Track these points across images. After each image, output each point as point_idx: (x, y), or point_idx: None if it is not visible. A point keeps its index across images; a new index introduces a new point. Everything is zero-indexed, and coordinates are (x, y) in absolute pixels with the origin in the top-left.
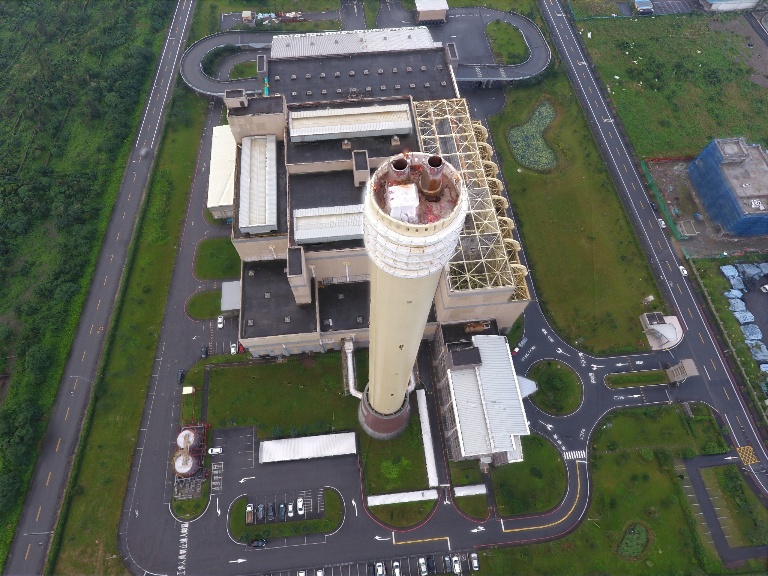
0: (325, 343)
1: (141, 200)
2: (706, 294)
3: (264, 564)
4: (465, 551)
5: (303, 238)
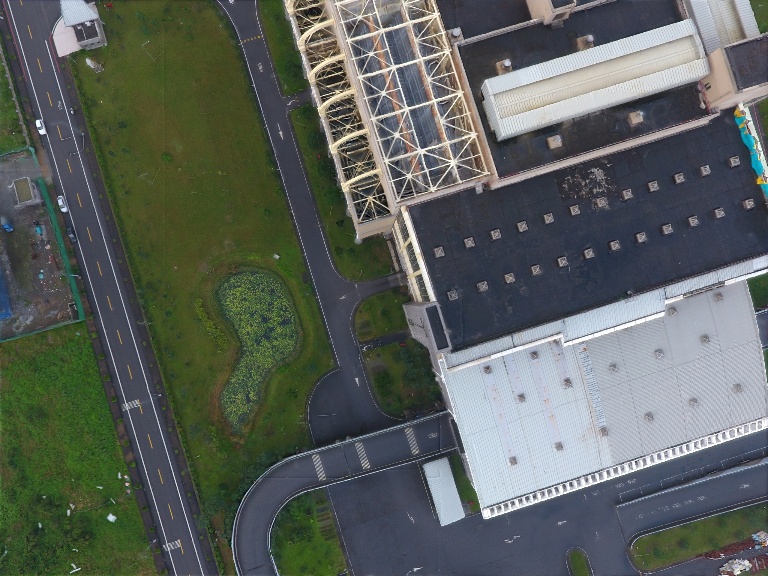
0: None
1: None
2: (14, 94)
3: None
4: None
5: None
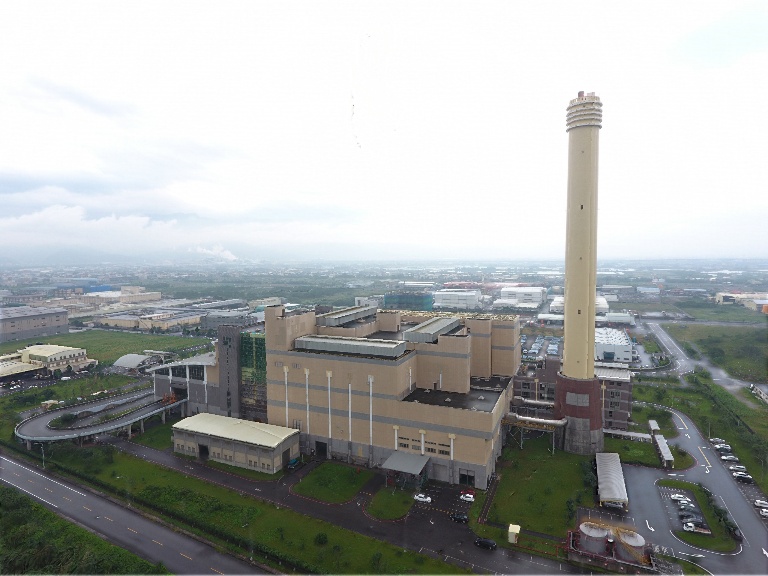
0: (499, 433)
1: (157, 521)
2: None
3: (763, 537)
4: (709, 443)
5: (434, 332)
